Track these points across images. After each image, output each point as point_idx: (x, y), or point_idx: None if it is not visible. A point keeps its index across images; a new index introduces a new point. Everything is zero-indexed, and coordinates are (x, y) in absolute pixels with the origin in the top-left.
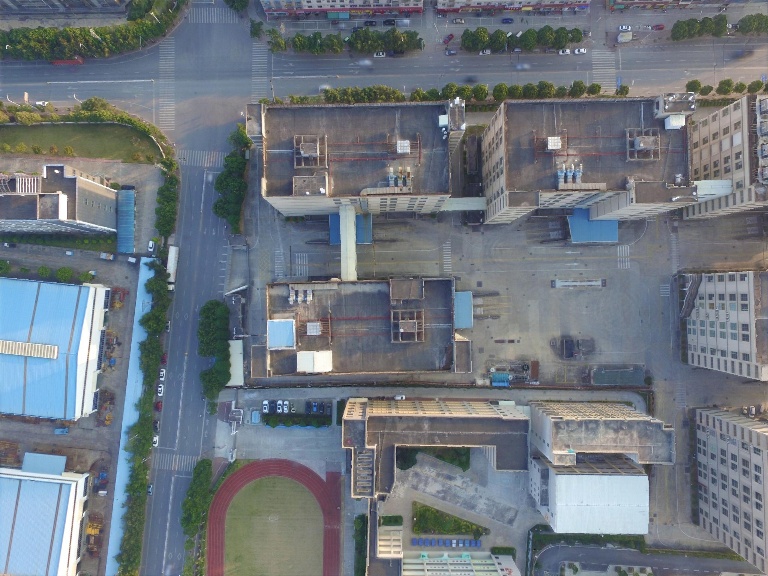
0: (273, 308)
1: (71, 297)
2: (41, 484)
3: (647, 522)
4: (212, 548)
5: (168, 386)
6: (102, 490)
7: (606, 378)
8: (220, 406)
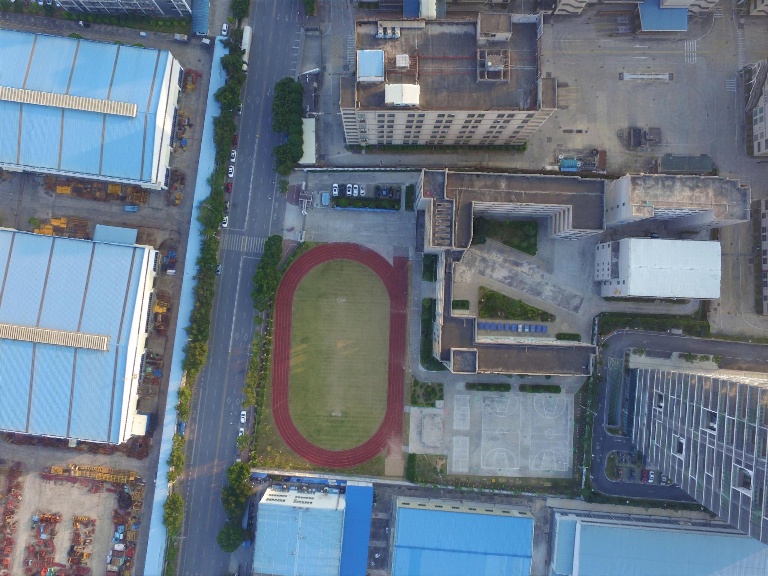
0: (361, 46)
1: (150, 60)
2: (115, 247)
3: (719, 286)
4: (279, 329)
5: (238, 168)
6: (170, 269)
7: (674, 164)
8: (290, 189)
